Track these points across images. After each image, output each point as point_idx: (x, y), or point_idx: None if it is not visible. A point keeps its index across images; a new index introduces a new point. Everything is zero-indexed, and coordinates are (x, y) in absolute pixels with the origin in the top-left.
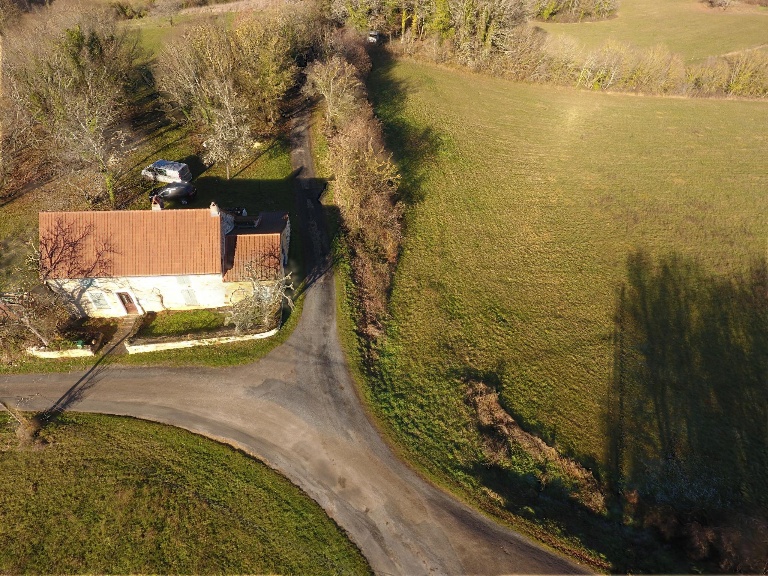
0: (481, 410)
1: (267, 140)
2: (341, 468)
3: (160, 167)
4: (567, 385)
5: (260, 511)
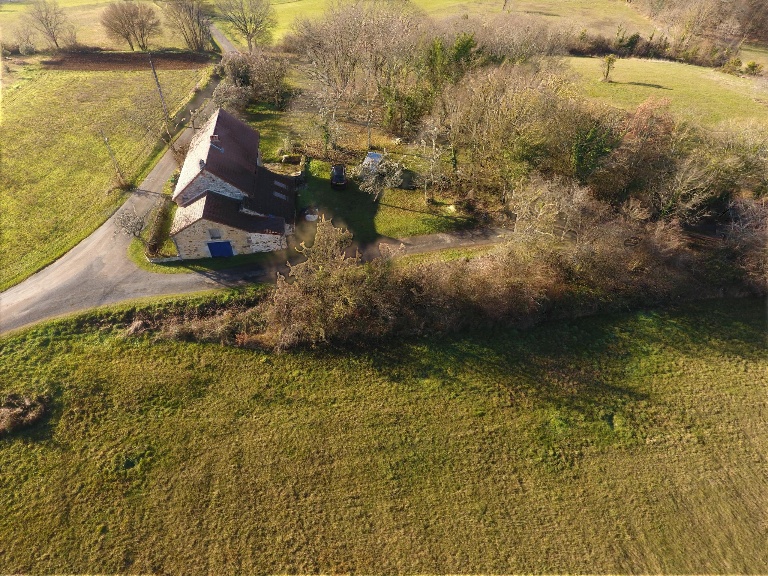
0: (1, 410)
1: (464, 212)
2: (1, 309)
3: (367, 157)
4: (5, 528)
5: (1, 276)
